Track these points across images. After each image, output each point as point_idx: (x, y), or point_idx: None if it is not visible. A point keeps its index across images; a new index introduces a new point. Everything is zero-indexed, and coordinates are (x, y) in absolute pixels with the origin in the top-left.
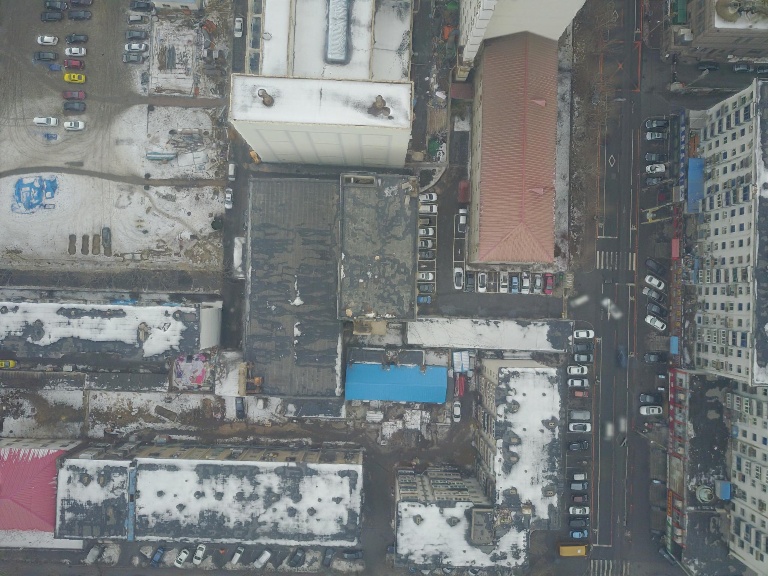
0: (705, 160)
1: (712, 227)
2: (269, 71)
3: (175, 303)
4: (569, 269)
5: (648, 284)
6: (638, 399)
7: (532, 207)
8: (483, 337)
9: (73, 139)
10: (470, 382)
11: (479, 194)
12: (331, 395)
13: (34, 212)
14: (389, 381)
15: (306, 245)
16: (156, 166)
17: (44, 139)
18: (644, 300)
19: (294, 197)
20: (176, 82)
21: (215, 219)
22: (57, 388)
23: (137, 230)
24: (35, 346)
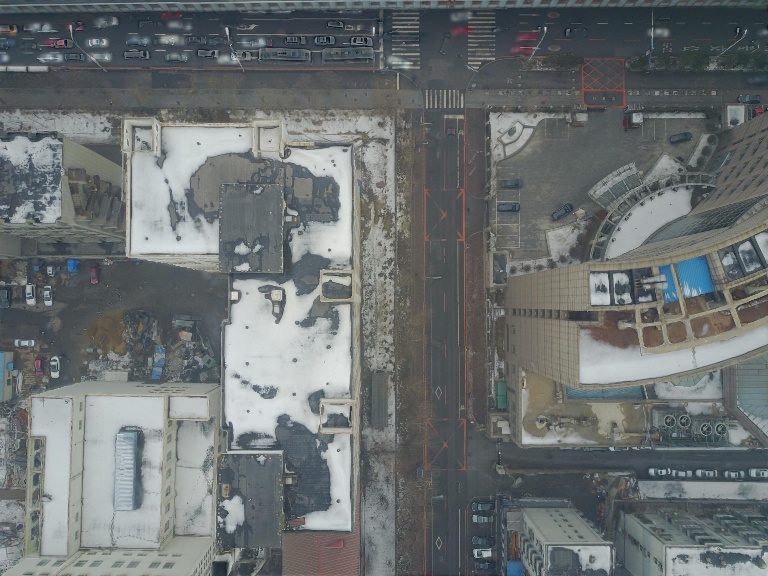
0: (522, 567)
1: None
2: (50, 534)
3: None
4: None
5: None
6: None
7: None
8: None
9: None
10: None
11: None
12: None
13: None
14: None
15: None
16: None
17: None
18: None
19: None
20: None
21: None
22: None
23: None
24: None
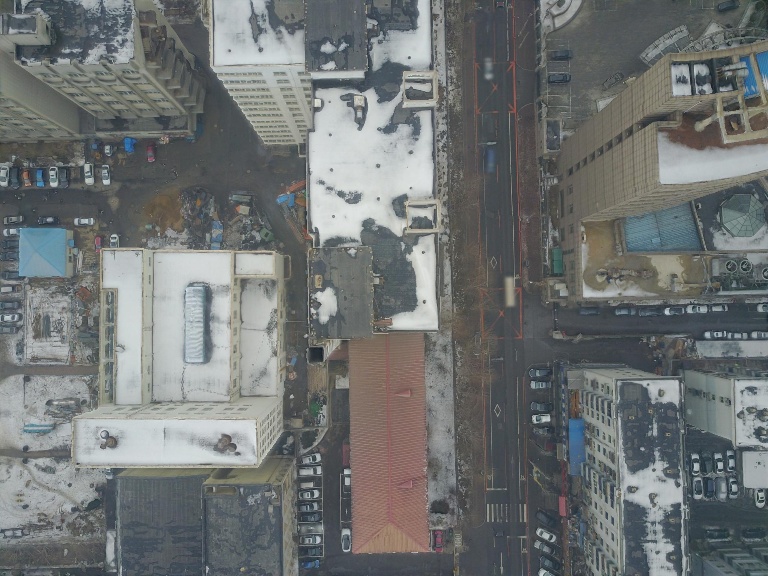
0: (584, 424)
1: (592, 497)
2: (124, 384)
3: None
4: (459, 525)
5: (539, 537)
6: None
7: (401, 504)
8: None
9: None
10: None
11: None
12: None
13: None
14: None
15: (176, 543)
16: (34, 438)
17: None
18: (536, 553)
19: (162, 494)
20: (52, 350)
21: (96, 490)
22: None
23: (17, 504)
24: None
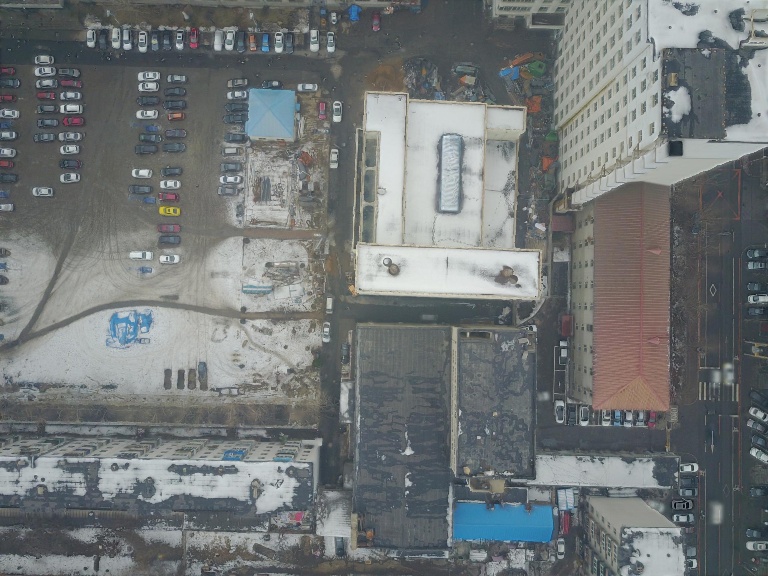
0: None
1: None
2: (384, 226)
3: (286, 457)
4: (672, 401)
5: (752, 416)
6: (744, 534)
7: (649, 358)
8: (588, 474)
9: (168, 272)
10: (573, 517)
11: (590, 339)
12: (443, 546)
13: (129, 347)
14: (494, 522)
15: (416, 393)
16: (252, 299)
17: (139, 273)
18: (748, 432)
19: (403, 345)
20: (271, 214)
21: (312, 353)
22: (155, 528)
23: (233, 364)
24: (146, 504)
